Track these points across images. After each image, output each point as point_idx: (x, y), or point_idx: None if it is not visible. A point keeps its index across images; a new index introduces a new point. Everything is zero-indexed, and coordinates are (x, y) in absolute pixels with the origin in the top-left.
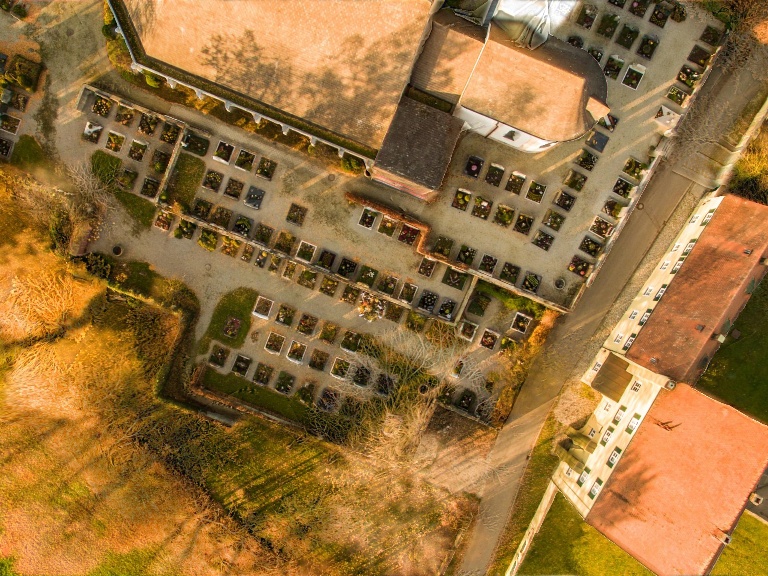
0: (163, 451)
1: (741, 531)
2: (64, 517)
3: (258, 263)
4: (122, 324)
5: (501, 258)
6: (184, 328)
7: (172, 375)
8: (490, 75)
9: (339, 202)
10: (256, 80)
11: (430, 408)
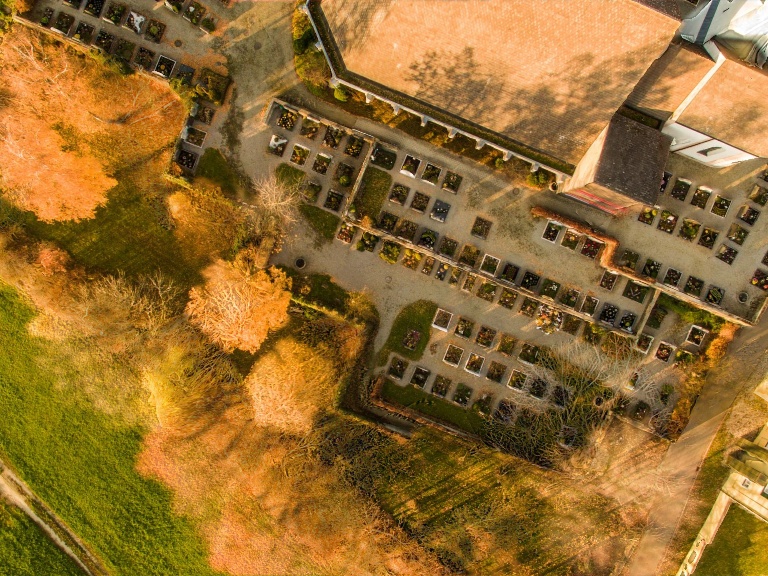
0: (335, 462)
1: None
2: (227, 527)
3: (438, 276)
4: (297, 336)
5: (685, 272)
6: (366, 340)
7: (350, 387)
8: (717, 93)
9: (523, 216)
10: (460, 96)
11: (606, 420)
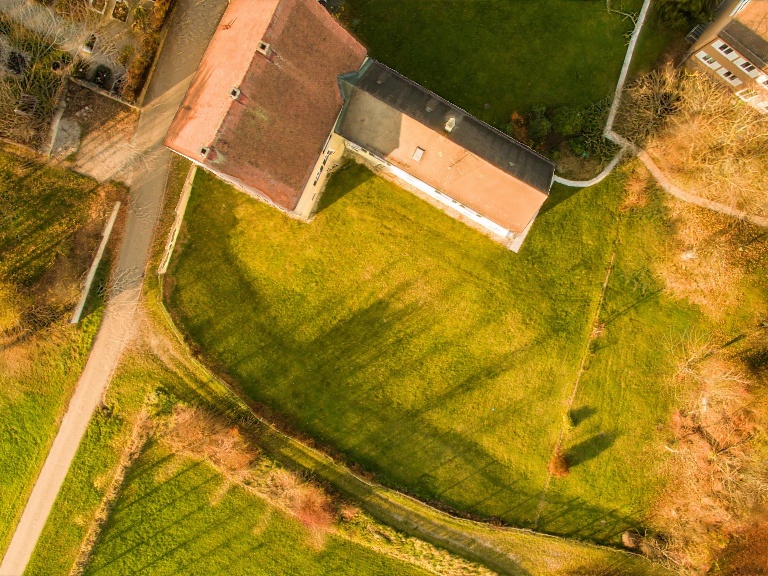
0: None
1: (397, 208)
2: None
3: None
4: None
5: None
6: None
7: None
8: None
9: None
10: None
11: (61, 83)
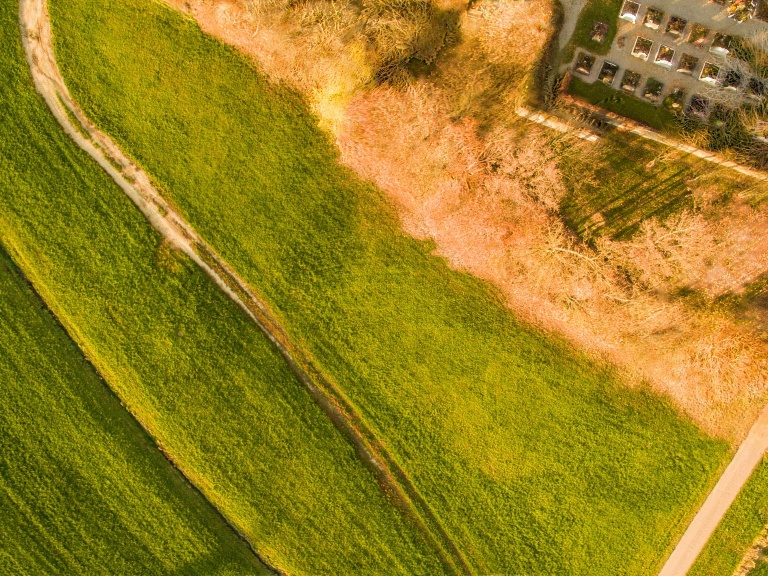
0: (516, 176)
1: None
2: (397, 263)
3: None
4: (474, 42)
5: None
6: (554, 31)
7: (534, 87)
8: None
9: None
10: None
11: None
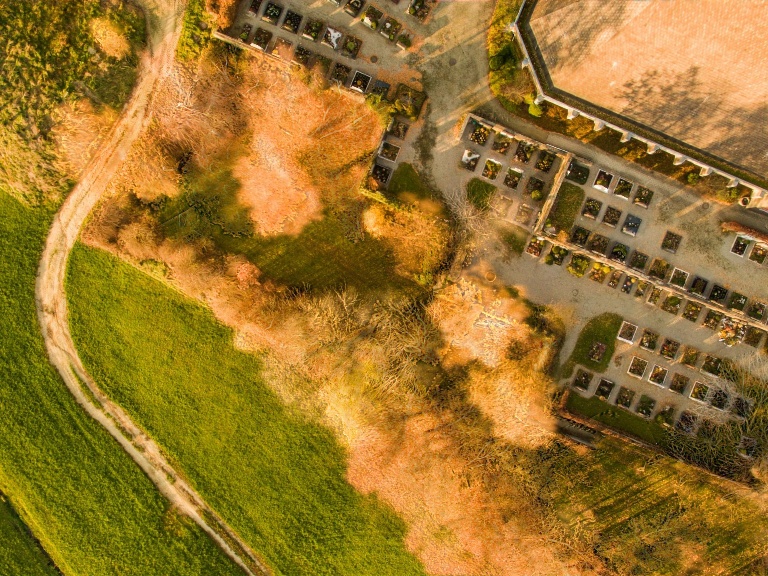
0: (514, 473)
1: None
2: (397, 537)
3: (625, 289)
4: (479, 348)
5: None
6: (555, 353)
7: None
8: None
9: (712, 230)
10: (670, 113)
11: None
